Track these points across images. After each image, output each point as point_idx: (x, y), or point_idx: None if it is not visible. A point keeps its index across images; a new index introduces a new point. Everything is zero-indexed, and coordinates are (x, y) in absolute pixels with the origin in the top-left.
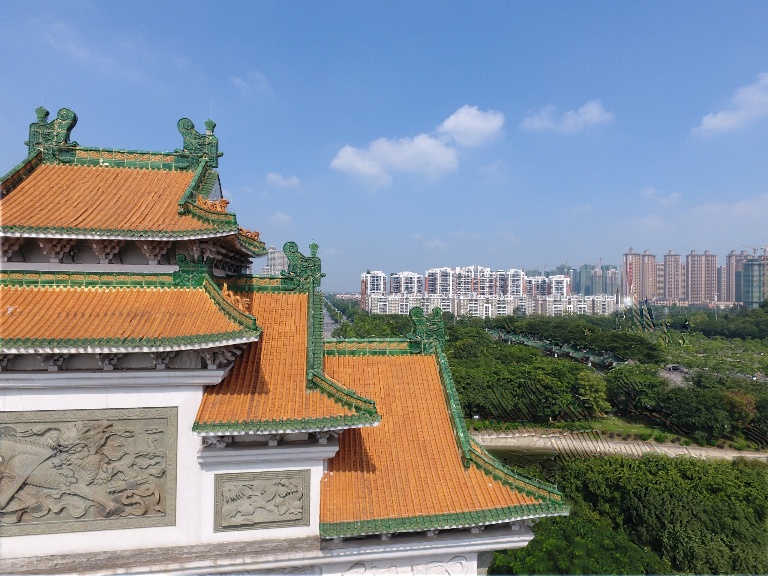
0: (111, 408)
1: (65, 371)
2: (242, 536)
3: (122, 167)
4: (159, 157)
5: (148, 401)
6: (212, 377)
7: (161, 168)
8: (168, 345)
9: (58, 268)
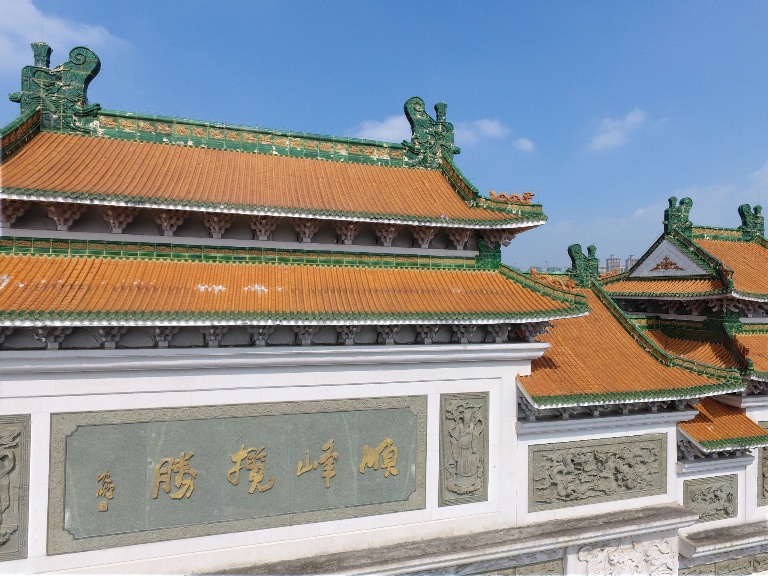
0: None
1: None
2: None
3: (716, 240)
4: (734, 232)
5: None
6: None
7: (736, 240)
8: None
9: None
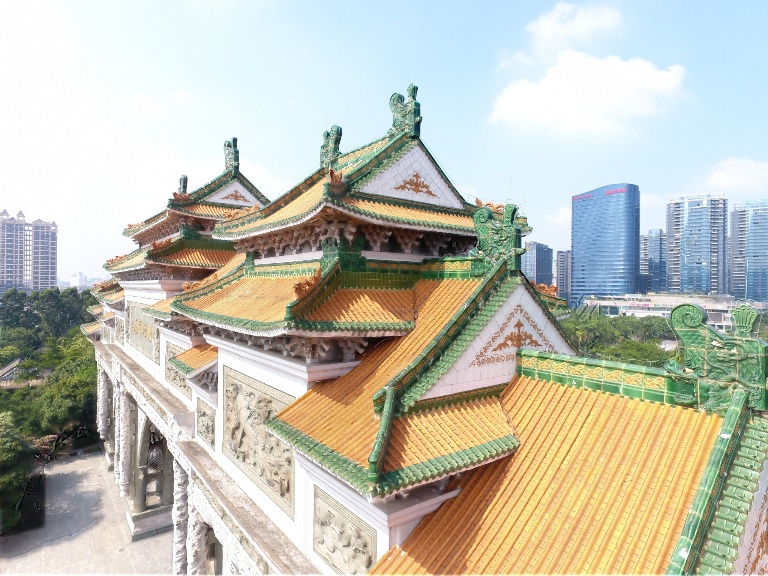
0: (270, 385)
1: (251, 346)
2: (329, 573)
3: None
4: (379, 144)
5: (284, 386)
6: (302, 372)
7: None
8: (257, 330)
9: (277, 260)
